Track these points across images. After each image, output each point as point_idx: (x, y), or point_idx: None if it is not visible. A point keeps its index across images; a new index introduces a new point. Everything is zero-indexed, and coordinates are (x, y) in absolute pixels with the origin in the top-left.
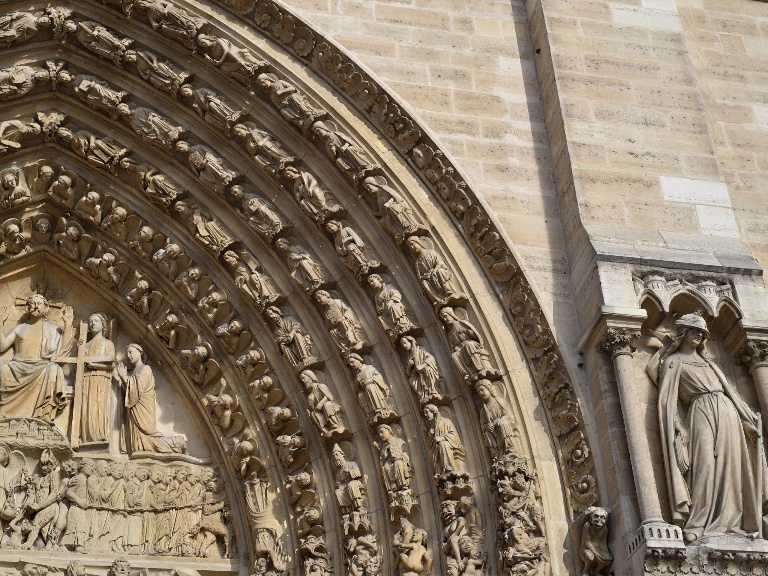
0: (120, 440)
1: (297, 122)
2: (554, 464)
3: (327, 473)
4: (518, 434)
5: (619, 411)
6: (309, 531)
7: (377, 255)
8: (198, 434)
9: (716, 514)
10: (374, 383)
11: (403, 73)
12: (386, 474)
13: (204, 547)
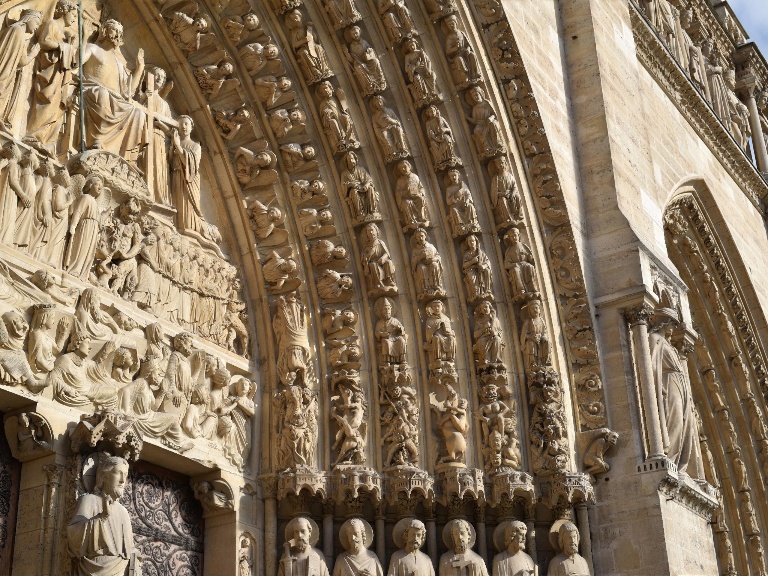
0: None
1: (438, 5)
2: (568, 383)
3: (365, 318)
4: None
5: (631, 364)
6: None
7: (457, 153)
8: (219, 228)
9: (681, 460)
10: (438, 262)
11: (513, 8)
12: (440, 344)
13: None
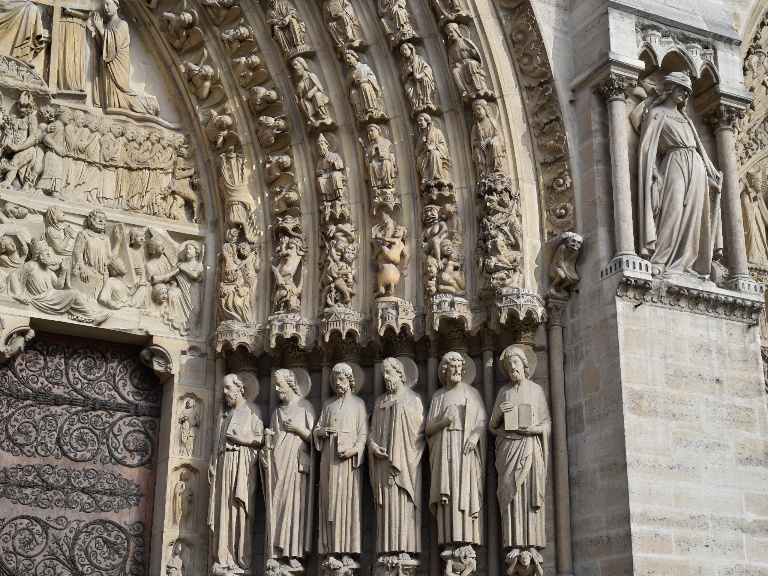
0: (93, 92)
1: None
2: (534, 187)
3: (307, 159)
4: (505, 155)
5: (606, 151)
6: (285, 211)
7: None
8: (169, 98)
9: (678, 255)
10: (369, 83)
11: None
12: (373, 171)
13: (174, 209)
